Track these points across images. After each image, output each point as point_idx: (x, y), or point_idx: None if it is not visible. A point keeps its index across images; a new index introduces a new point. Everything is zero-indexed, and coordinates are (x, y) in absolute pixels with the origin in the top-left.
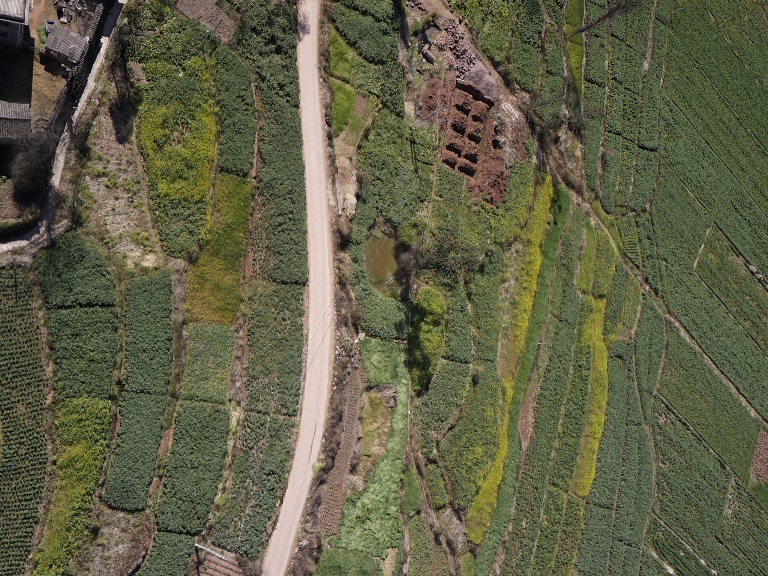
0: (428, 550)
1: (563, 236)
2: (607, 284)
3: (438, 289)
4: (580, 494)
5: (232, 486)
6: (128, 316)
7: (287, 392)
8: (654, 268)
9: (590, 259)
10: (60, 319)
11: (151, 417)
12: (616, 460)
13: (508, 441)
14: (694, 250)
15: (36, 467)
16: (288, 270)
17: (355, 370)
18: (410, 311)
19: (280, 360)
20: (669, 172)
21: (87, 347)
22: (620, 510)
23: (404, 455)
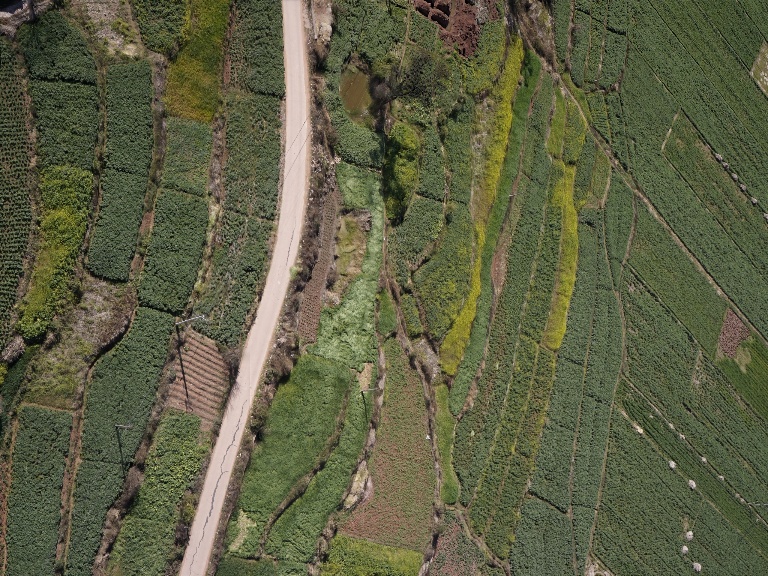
0: (403, 372)
1: (534, 100)
2: (577, 152)
3: (412, 127)
4: (552, 346)
5: (212, 277)
6: (109, 98)
7: (265, 196)
8: (623, 144)
9: (560, 126)
10: (43, 89)
11: (132, 195)
12: (587, 319)
13: (481, 284)
14: (662, 133)
15: (21, 223)
16: (265, 81)
17: (331, 191)
18: (385, 144)
19: (258, 165)
20: (637, 57)
21: (70, 119)
22: (591, 367)
23: (379, 278)
